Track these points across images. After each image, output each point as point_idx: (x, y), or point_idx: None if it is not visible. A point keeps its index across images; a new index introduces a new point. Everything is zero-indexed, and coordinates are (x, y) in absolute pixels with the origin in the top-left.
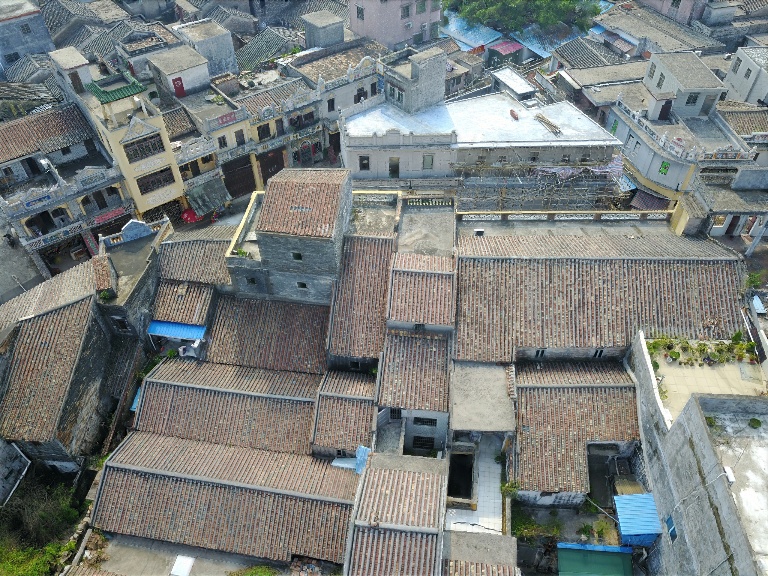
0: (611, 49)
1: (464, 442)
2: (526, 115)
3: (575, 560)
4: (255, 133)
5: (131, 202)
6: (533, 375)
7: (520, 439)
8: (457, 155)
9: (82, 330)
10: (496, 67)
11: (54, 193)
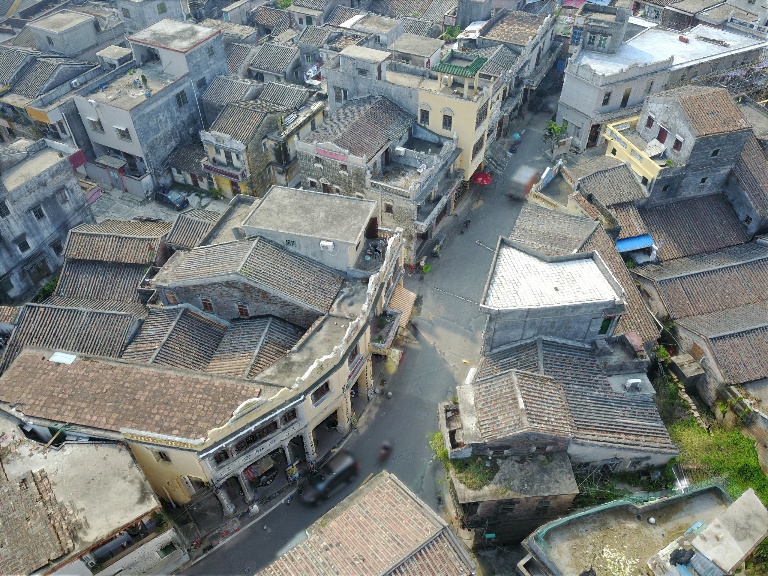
0: None
1: None
2: None
3: None
4: None
5: (463, 172)
6: None
7: None
8: (669, 77)
9: (615, 250)
10: None
11: (432, 172)
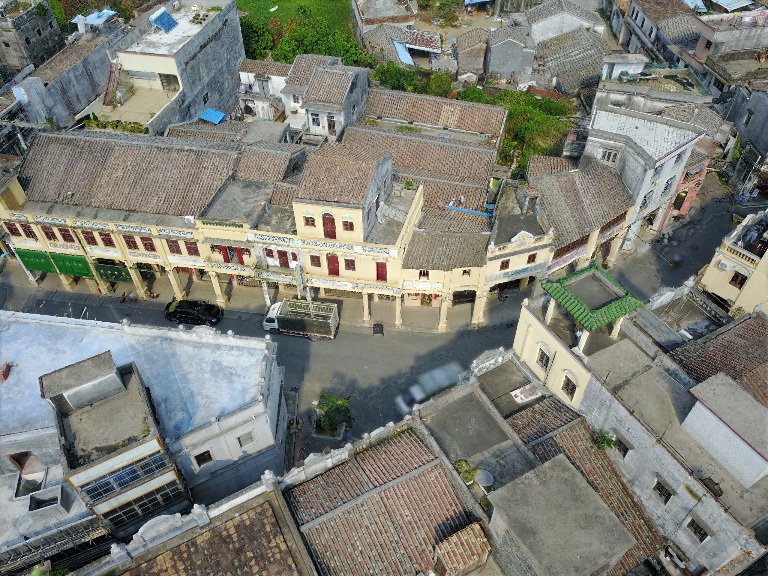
0: None
1: None
2: None
3: None
4: None
5: None
6: None
7: None
8: None
9: None
10: None
11: None
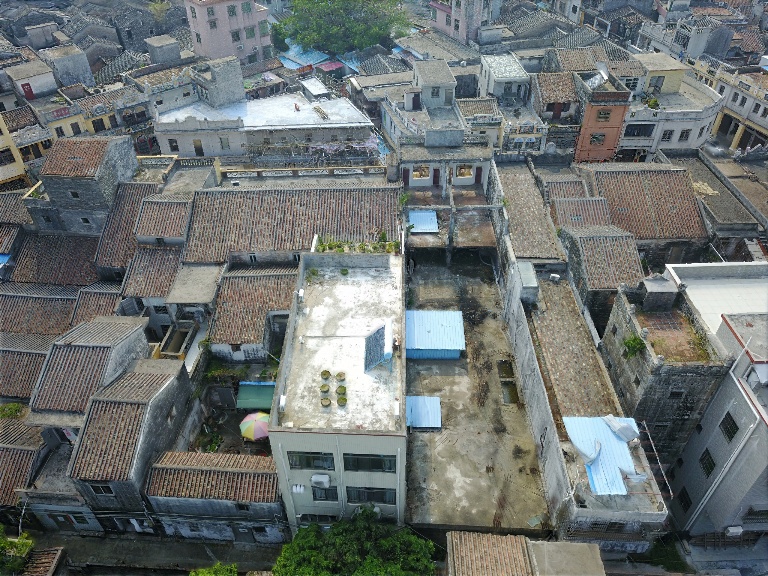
0: (406, 64)
1: (186, 320)
2: (307, 107)
3: (251, 392)
4: (90, 126)
5: None
6: (241, 271)
7: (219, 311)
8: (247, 137)
9: None
10: (323, 82)
11: None
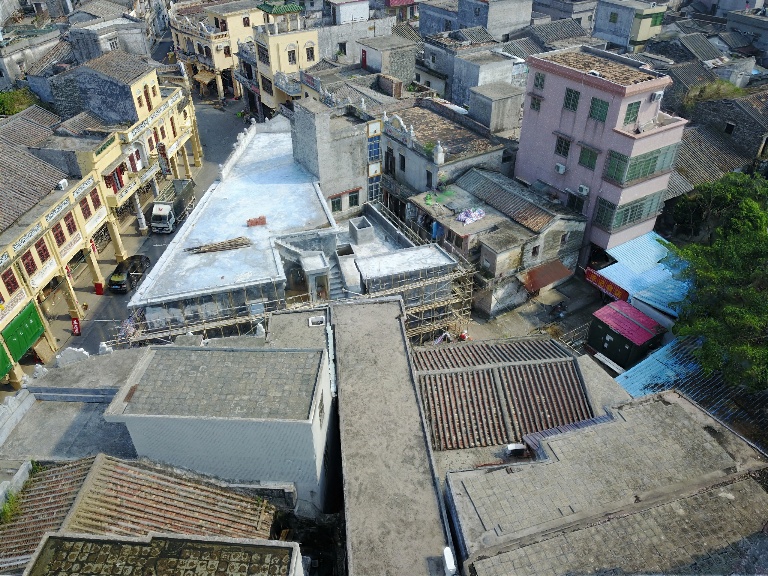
0: None
1: None
2: (257, 234)
3: None
4: None
5: None
6: None
7: None
8: None
9: None
10: None
11: None
